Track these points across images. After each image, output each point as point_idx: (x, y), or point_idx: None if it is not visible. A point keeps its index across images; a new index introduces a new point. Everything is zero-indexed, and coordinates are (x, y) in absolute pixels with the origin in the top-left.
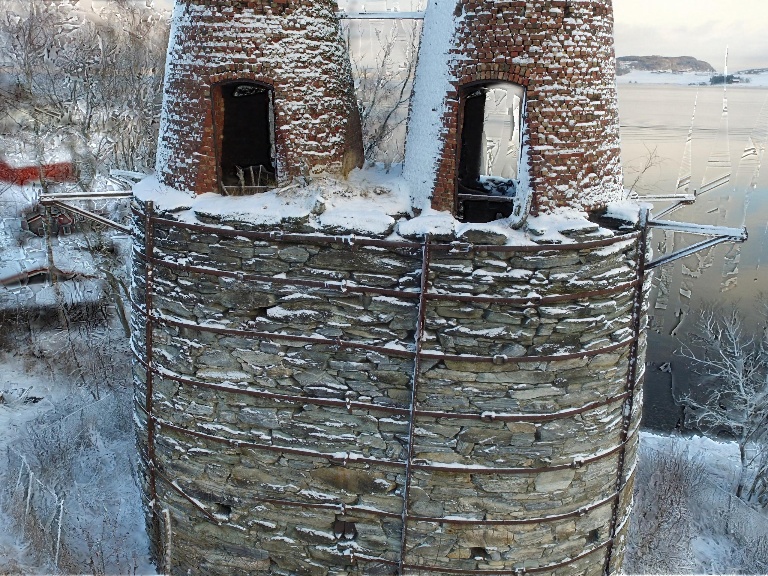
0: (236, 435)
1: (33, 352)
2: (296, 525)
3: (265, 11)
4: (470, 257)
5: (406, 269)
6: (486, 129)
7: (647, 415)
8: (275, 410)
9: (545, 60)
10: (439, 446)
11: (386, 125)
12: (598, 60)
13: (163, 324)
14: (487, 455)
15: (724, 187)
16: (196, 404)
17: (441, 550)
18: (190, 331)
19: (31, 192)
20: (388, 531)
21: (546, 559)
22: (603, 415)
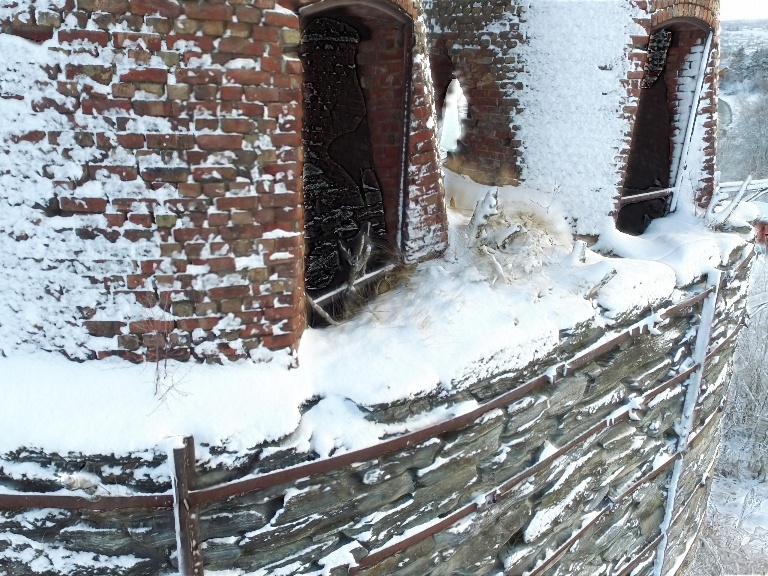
0: None
1: None
2: None
3: None
4: None
5: None
6: None
7: None
8: None
9: None
10: None
11: None
12: None
13: None
14: None
15: None
16: None
17: None
18: None
19: None
20: None
21: None
22: None
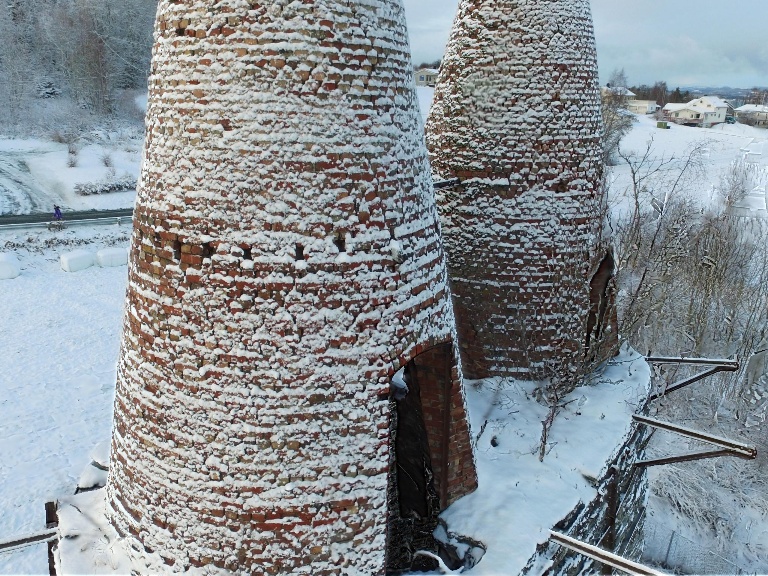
0: None
1: None
2: None
3: None
4: None
5: None
6: None
7: None
8: None
9: None
10: None
11: None
12: None
13: None
14: None
15: None
16: None
17: None
18: None
19: None
20: None
21: None
22: None
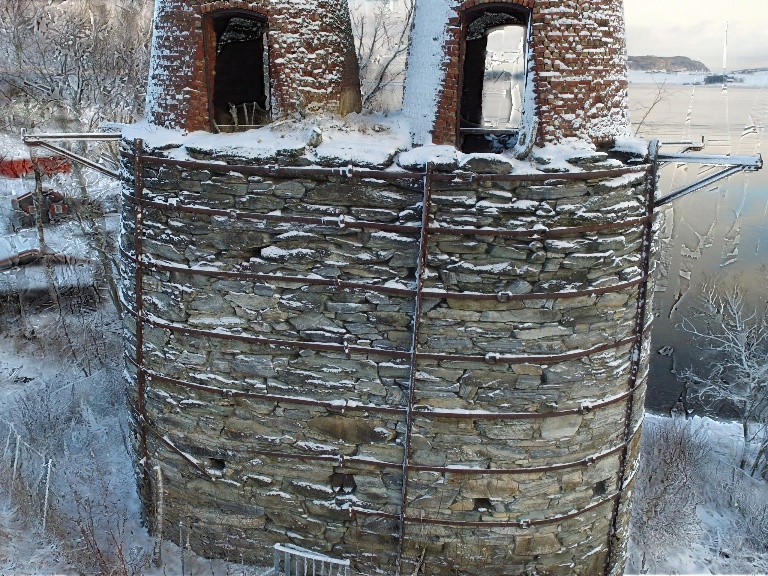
0: (230, 384)
1: (24, 334)
2: (292, 479)
3: None
4: (473, 187)
5: (407, 202)
6: (484, 109)
7: (647, 397)
8: (270, 357)
9: None
10: (441, 391)
11: None
12: None
13: (153, 269)
14: (491, 399)
15: None
16: (188, 353)
17: (443, 501)
18: (181, 275)
19: (21, 169)
20: (388, 483)
21: (552, 511)
22: (611, 358)
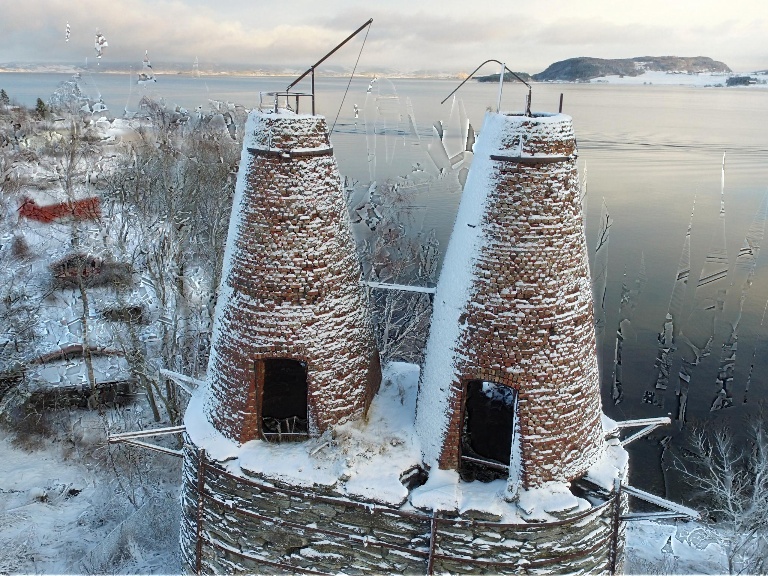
0: None
1: (70, 438)
2: None
3: (301, 303)
4: (471, 529)
5: (417, 532)
6: None
7: None
8: None
9: (534, 370)
10: None
11: (400, 230)
12: (579, 361)
13: (212, 547)
14: None
15: (722, 281)
16: None
17: None
18: (235, 556)
19: (71, 298)
20: None
21: None
22: None
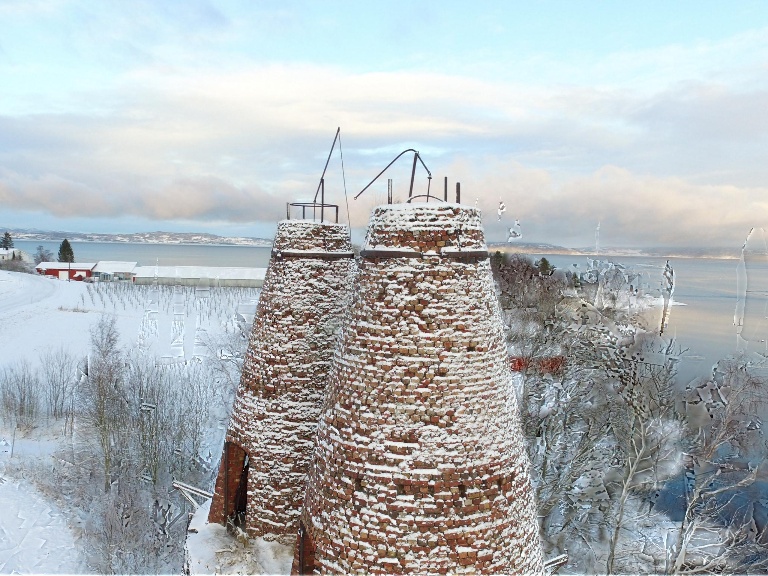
0: None
1: None
2: None
3: (259, 395)
4: None
5: None
6: None
7: None
8: None
9: (331, 531)
10: None
11: (735, 422)
12: (399, 549)
13: None
14: None
15: None
16: None
17: None
18: None
19: None
20: None
21: None
22: None
